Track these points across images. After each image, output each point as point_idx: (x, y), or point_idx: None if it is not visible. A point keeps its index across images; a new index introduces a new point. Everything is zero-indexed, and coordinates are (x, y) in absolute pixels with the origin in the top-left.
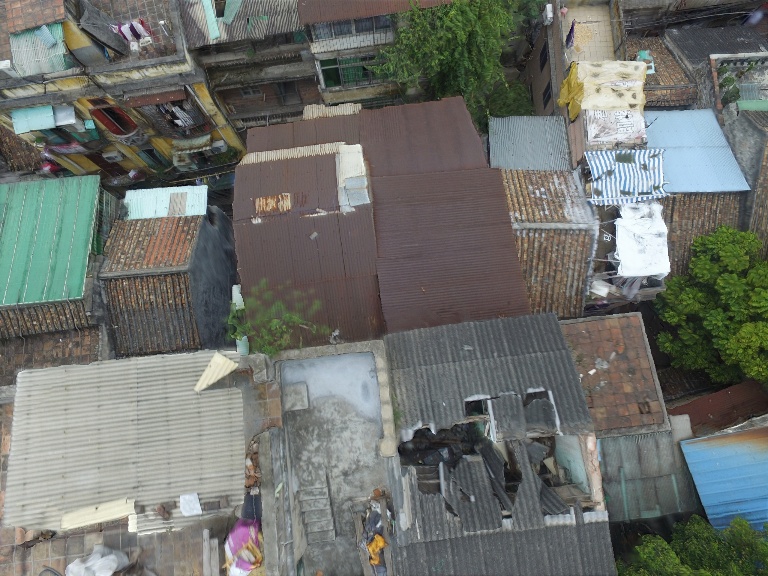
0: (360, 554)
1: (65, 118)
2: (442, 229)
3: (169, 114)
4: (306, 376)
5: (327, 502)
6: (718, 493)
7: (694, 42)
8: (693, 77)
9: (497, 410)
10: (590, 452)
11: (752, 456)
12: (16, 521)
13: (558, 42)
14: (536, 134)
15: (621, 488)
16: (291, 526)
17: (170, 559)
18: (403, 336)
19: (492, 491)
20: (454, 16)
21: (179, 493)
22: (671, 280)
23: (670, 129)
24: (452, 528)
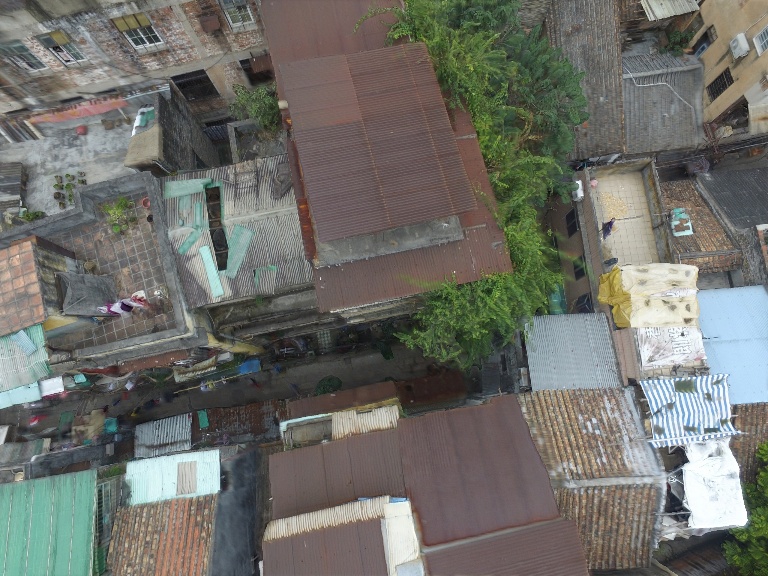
0: None
1: (52, 387)
2: None
3: (169, 363)
4: None
5: None
6: None
7: (731, 192)
8: (736, 241)
9: None
10: None
11: None
12: None
13: (592, 226)
14: (577, 339)
15: None
16: None
17: None
18: None
19: None
20: (499, 299)
21: None
22: None
23: (721, 315)
24: None
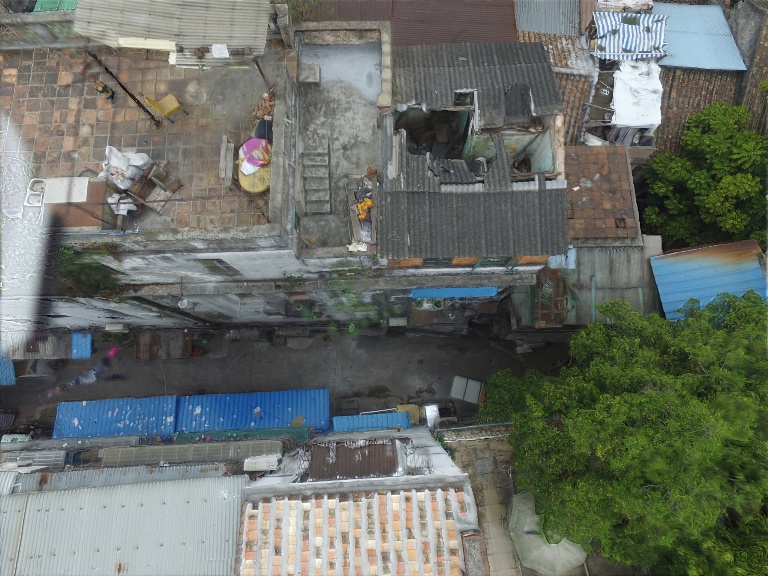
0: (350, 214)
1: None
2: (452, 3)
3: None
4: (320, 63)
5: (326, 171)
6: (679, 301)
7: None
8: None
9: (481, 100)
10: (557, 129)
11: (714, 269)
12: (82, 31)
13: None
14: (550, 5)
15: (591, 295)
16: (295, 158)
17: (191, 171)
18: (407, 48)
19: (470, 171)
20: None
21: (212, 43)
22: (663, 155)
23: (678, 17)
24: (431, 183)
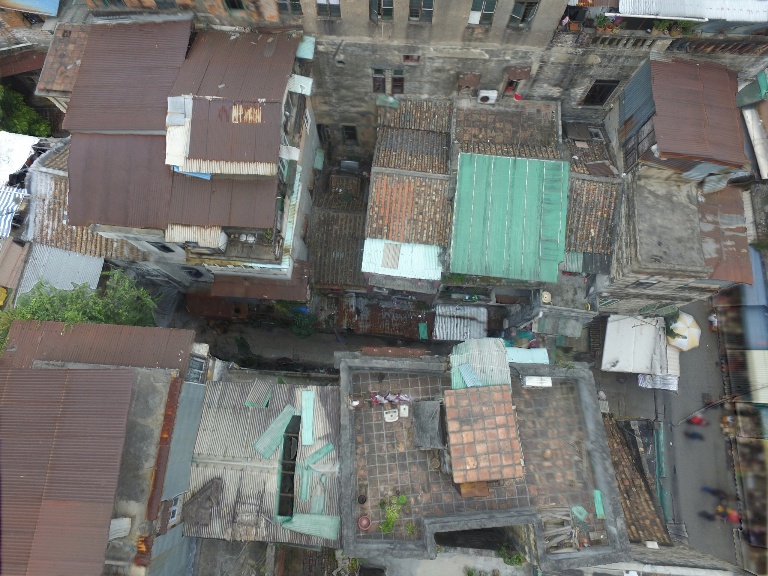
0: None
1: None
2: (126, 86)
3: None
4: None
5: None
6: None
7: None
8: None
9: None
10: None
11: None
12: None
13: None
14: None
15: None
16: None
17: None
18: None
19: None
20: None
21: None
22: None
23: None
24: None
